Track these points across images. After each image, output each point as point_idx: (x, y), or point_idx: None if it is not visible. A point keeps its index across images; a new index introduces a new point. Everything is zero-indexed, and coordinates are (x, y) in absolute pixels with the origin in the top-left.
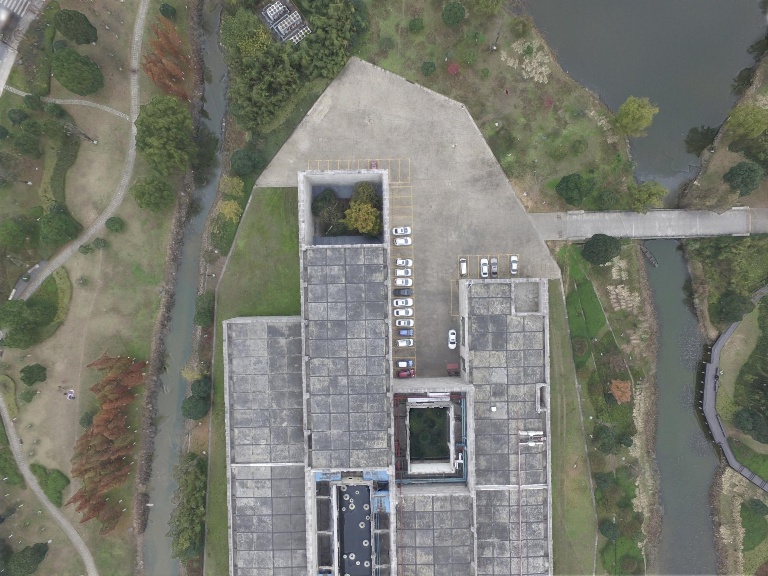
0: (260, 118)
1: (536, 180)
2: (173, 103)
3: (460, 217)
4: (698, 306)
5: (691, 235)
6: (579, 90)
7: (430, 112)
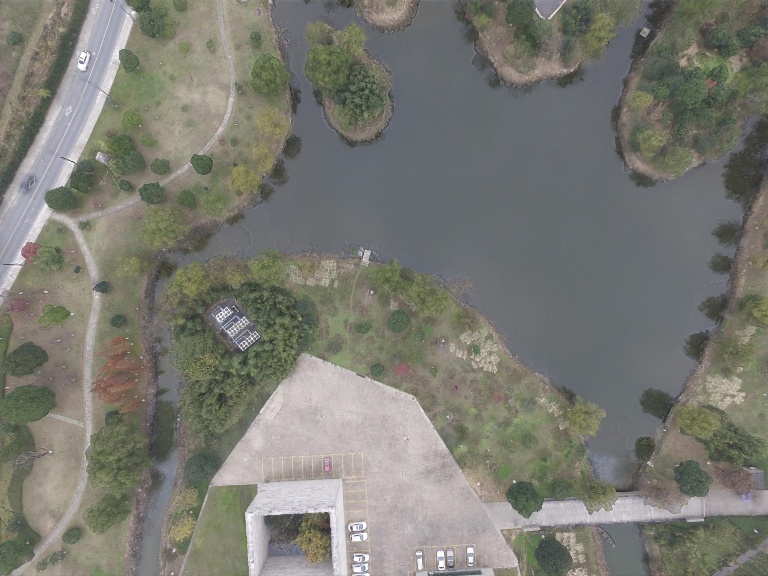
0: (212, 427)
1: (489, 469)
2: (122, 435)
3: (415, 509)
4: None
5: (646, 520)
6: (529, 376)
7: (381, 406)
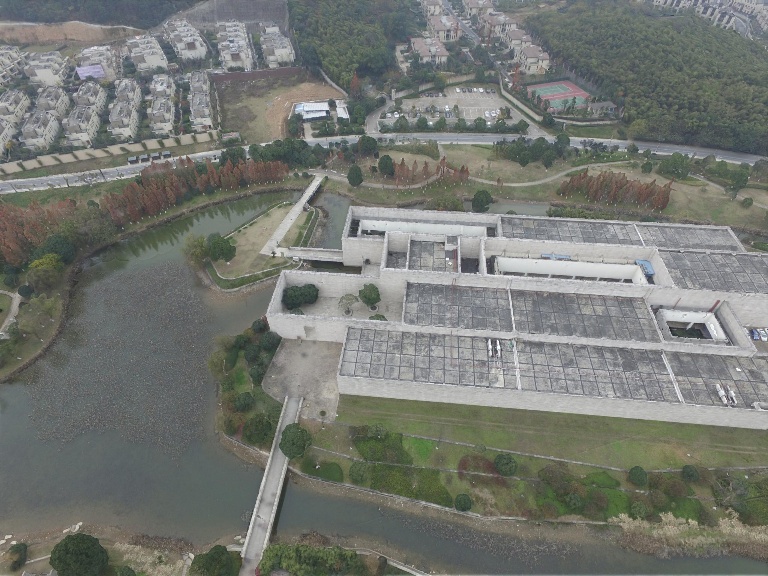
0: None
1: None
2: None
3: None
4: None
5: None
6: None
7: None
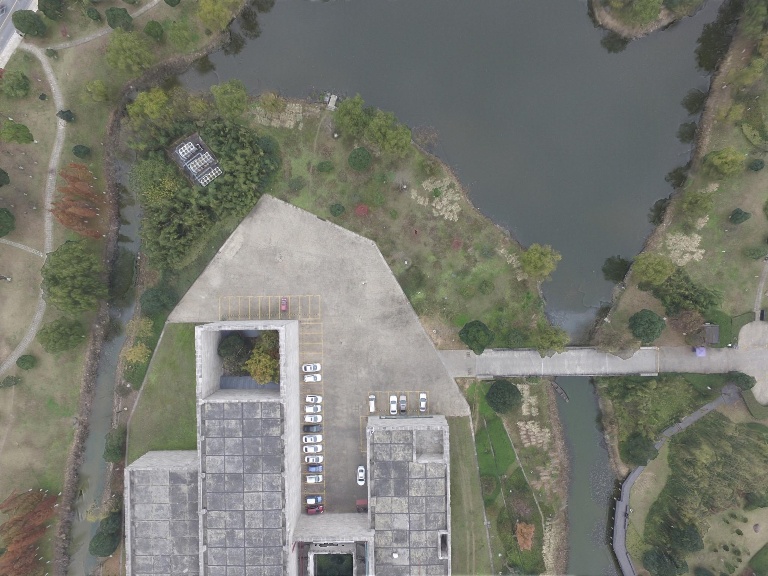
0: (170, 258)
1: (446, 317)
2: (78, 252)
3: (370, 354)
4: (609, 442)
5: (600, 374)
6: (489, 227)
7: (341, 249)
